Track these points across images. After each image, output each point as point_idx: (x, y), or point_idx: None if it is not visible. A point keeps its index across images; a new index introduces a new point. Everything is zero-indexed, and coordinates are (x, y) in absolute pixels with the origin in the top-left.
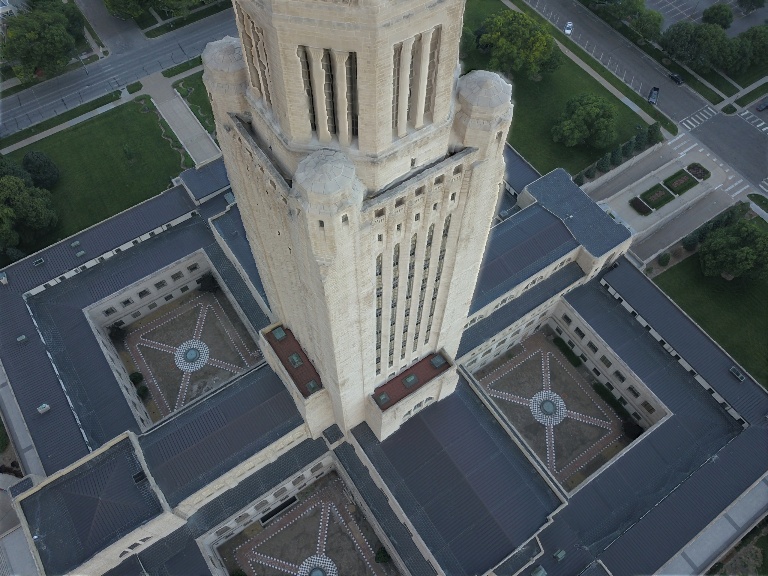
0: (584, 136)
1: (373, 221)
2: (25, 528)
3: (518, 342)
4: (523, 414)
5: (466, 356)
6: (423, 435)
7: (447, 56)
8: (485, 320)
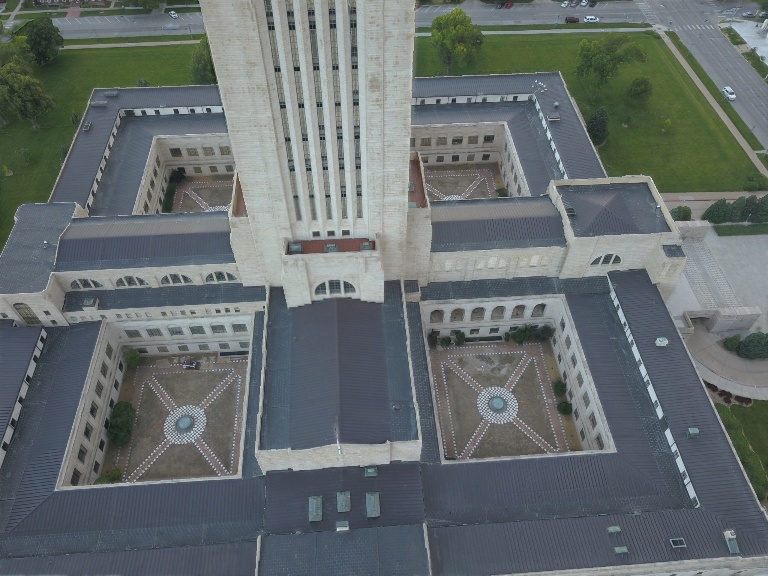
0: None
1: None
2: (667, 212)
3: None
4: None
5: None
6: None
7: None
8: None
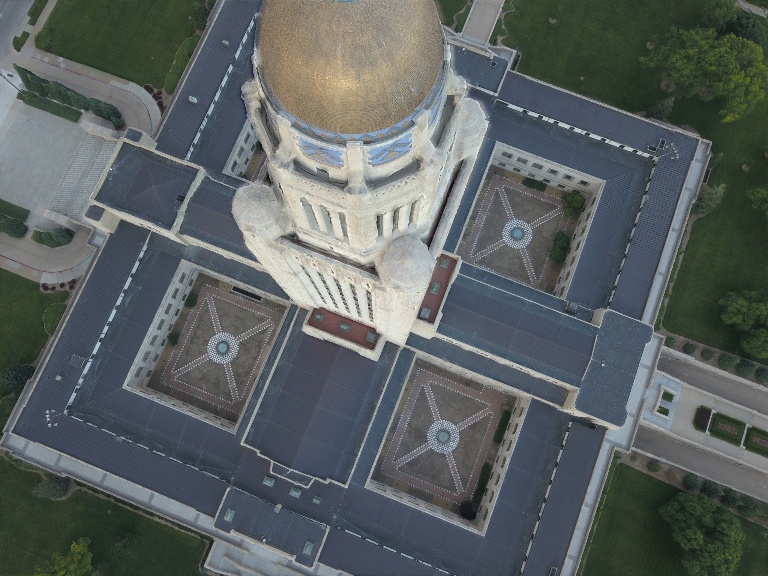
0: (743, 326)
1: (288, 250)
2: (111, 159)
3: (483, 384)
4: (426, 420)
5: (421, 352)
6: (328, 360)
7: (355, 229)
8: (461, 349)
